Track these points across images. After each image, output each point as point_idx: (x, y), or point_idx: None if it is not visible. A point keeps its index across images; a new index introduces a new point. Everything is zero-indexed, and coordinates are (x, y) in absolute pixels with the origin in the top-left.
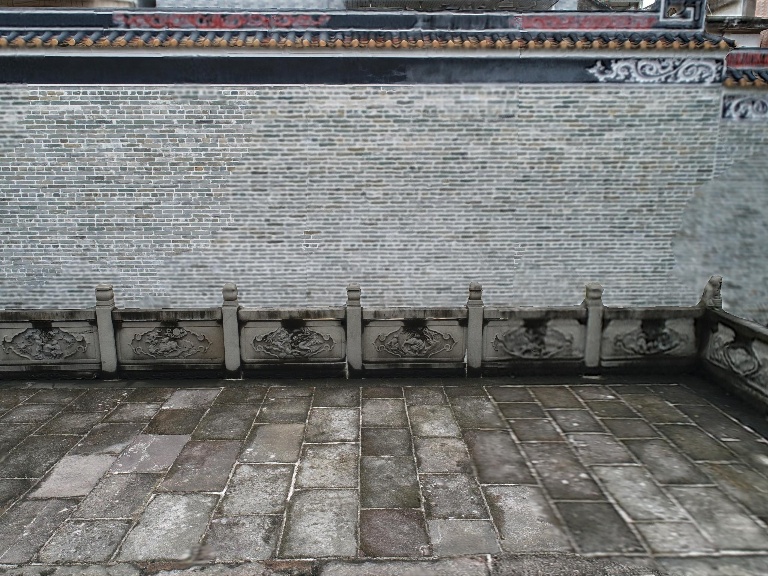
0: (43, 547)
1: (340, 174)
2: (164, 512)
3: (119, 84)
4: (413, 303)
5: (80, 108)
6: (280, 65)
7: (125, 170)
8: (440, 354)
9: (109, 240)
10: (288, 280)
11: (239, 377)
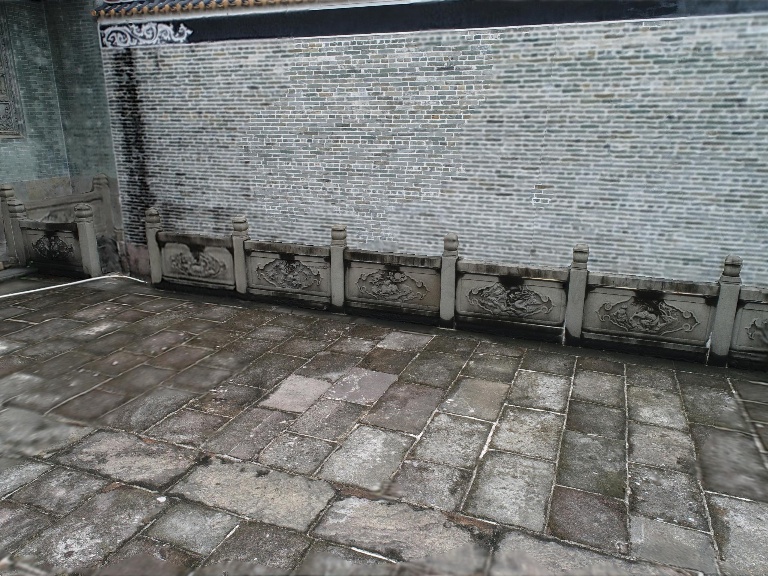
0: (263, 450)
1: (582, 124)
2: (364, 443)
3: (370, 34)
4: (652, 273)
5: (335, 59)
6: (528, 4)
7: (368, 118)
8: (676, 333)
9: (350, 184)
10: (513, 235)
11: (452, 327)
